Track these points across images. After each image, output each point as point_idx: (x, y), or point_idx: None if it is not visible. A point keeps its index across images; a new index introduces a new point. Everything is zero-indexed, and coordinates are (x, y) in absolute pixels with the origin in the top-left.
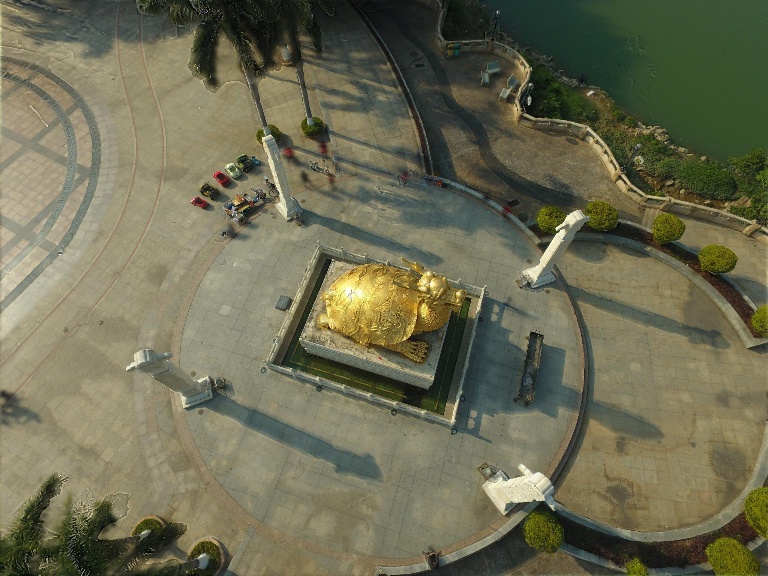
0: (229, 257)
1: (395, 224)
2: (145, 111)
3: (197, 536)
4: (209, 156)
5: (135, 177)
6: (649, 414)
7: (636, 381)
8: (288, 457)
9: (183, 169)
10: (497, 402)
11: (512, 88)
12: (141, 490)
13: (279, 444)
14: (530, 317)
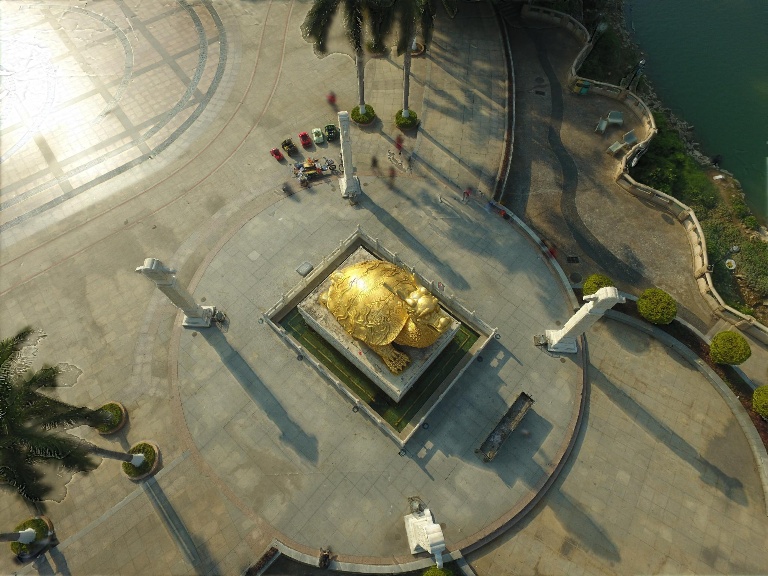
0: (279, 211)
1: (440, 236)
2: (270, 60)
3: (145, 437)
4: (304, 116)
5: (236, 114)
6: (615, 531)
7: (617, 491)
8: (246, 406)
9: (277, 120)
10: (458, 445)
11: (626, 144)
12: (121, 378)
13: (244, 391)
14: (532, 378)
